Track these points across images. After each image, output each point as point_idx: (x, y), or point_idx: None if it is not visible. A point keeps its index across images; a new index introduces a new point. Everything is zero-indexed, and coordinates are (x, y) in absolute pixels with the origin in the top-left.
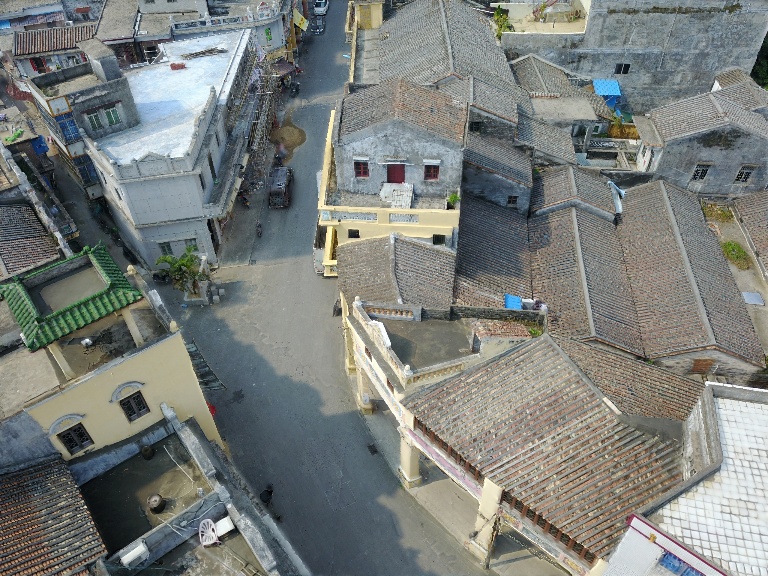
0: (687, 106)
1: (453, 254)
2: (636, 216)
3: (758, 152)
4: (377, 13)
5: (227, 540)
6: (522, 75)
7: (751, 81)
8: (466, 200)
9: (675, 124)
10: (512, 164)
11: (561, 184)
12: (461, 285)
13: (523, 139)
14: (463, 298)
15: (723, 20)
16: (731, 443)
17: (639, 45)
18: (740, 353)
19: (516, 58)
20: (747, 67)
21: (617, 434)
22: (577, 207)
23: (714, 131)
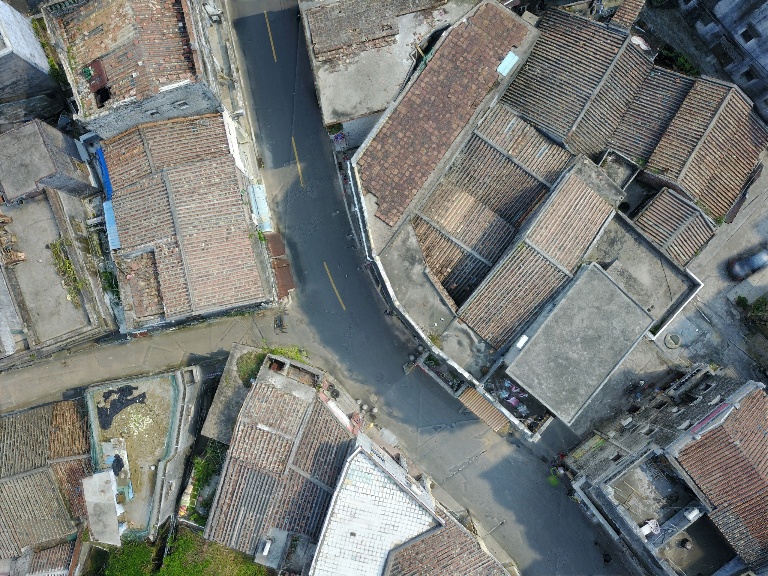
0: None
1: None
2: None
3: None
4: None
5: (642, 522)
6: None
7: None
8: None
9: None
10: None
11: None
12: None
13: None
14: None
15: None
16: (377, 567)
17: None
18: None
19: None
20: None
21: None
22: None
23: None
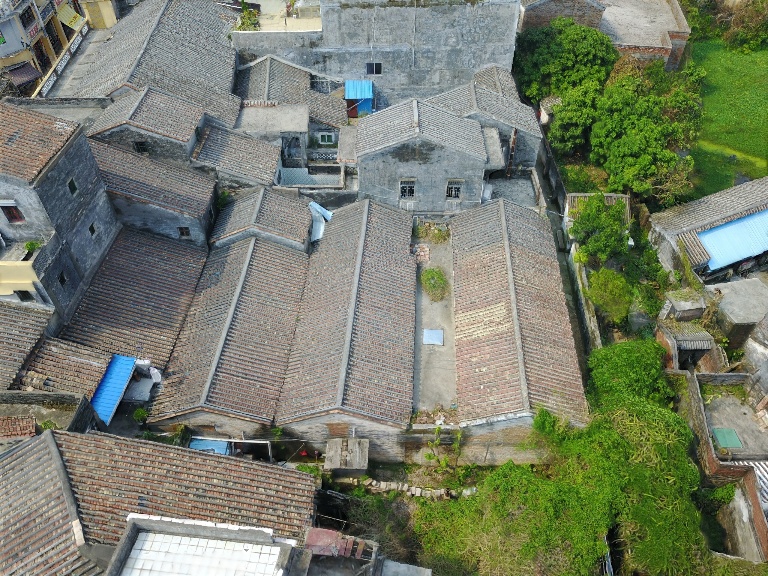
0: (390, 114)
1: (48, 311)
2: (331, 243)
3: (459, 165)
4: (108, 11)
5: None
6: (253, 79)
7: (508, 79)
8: (126, 234)
9: (372, 136)
10: (183, 189)
11: (247, 209)
12: (47, 351)
13: (205, 159)
14: (41, 369)
15: (467, 13)
16: None
17: (385, 42)
18: (375, 414)
19: (254, 60)
20: (506, 63)
21: (74, 572)
22: (258, 236)
23: (405, 144)
